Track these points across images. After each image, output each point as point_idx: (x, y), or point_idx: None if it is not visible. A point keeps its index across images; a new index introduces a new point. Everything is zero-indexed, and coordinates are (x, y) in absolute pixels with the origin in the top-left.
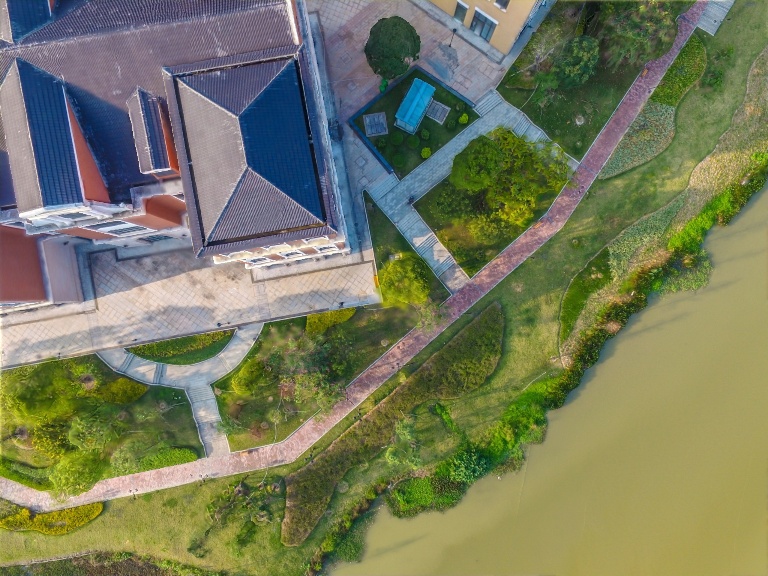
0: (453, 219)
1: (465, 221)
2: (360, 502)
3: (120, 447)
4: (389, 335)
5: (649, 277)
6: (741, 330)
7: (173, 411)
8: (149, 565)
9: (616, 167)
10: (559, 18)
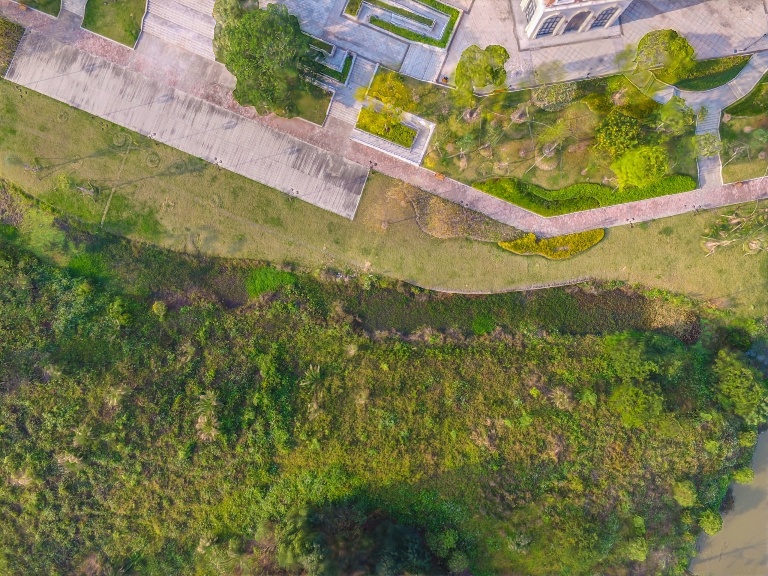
0: None
1: None
2: None
3: None
4: None
5: None
6: None
7: (684, 136)
8: (637, 295)
9: None
10: None
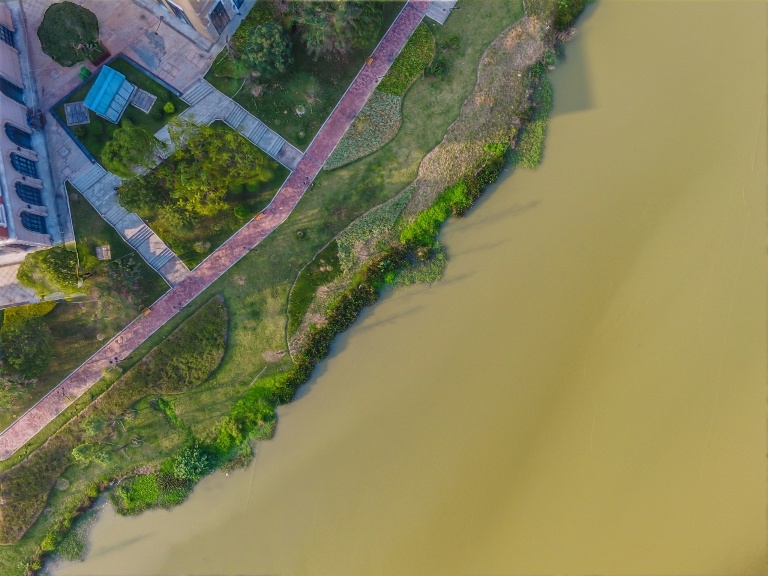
0: (133, 209)
1: (152, 211)
2: (82, 500)
3: None
4: (104, 329)
5: (378, 270)
6: (477, 324)
7: None
8: None
9: (341, 158)
10: (269, 5)
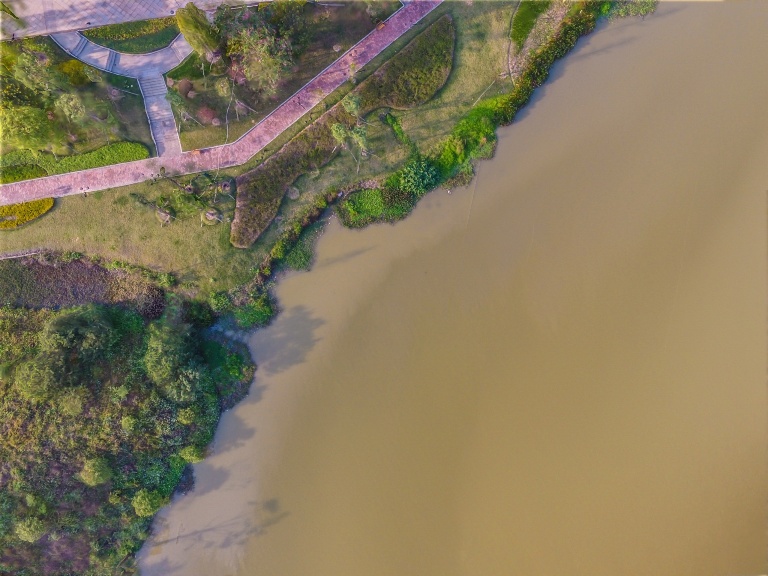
0: None
1: None
2: (311, 211)
3: (71, 131)
4: (341, 40)
5: None
6: (688, 56)
7: (125, 101)
8: (99, 268)
9: None
10: None
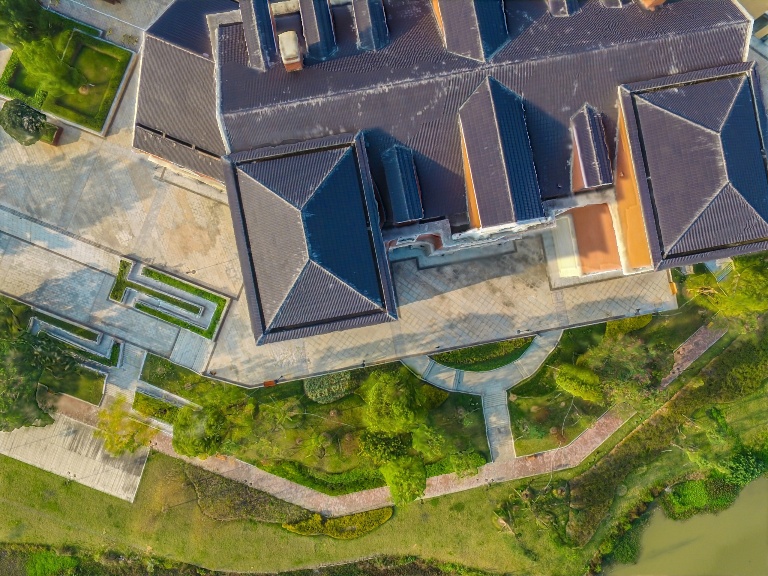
0: None
1: None
2: (637, 505)
3: None
4: (672, 341)
5: None
6: None
7: (469, 417)
8: (431, 568)
9: None
10: None
